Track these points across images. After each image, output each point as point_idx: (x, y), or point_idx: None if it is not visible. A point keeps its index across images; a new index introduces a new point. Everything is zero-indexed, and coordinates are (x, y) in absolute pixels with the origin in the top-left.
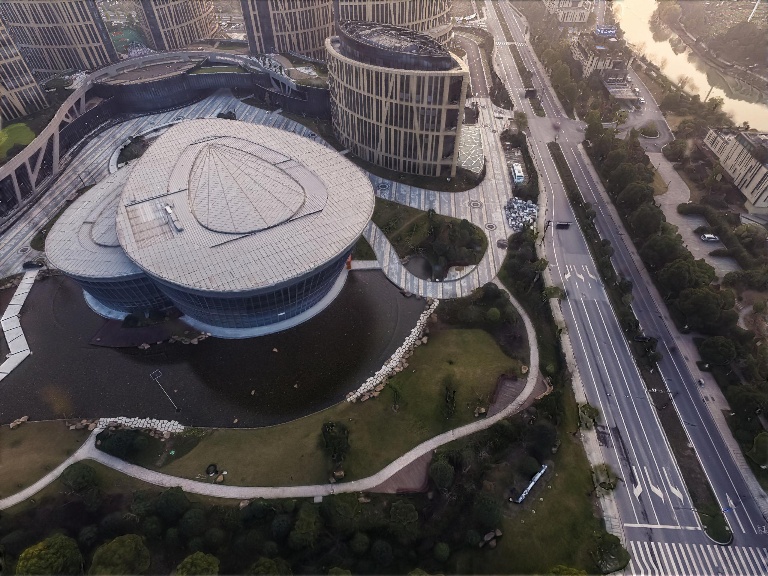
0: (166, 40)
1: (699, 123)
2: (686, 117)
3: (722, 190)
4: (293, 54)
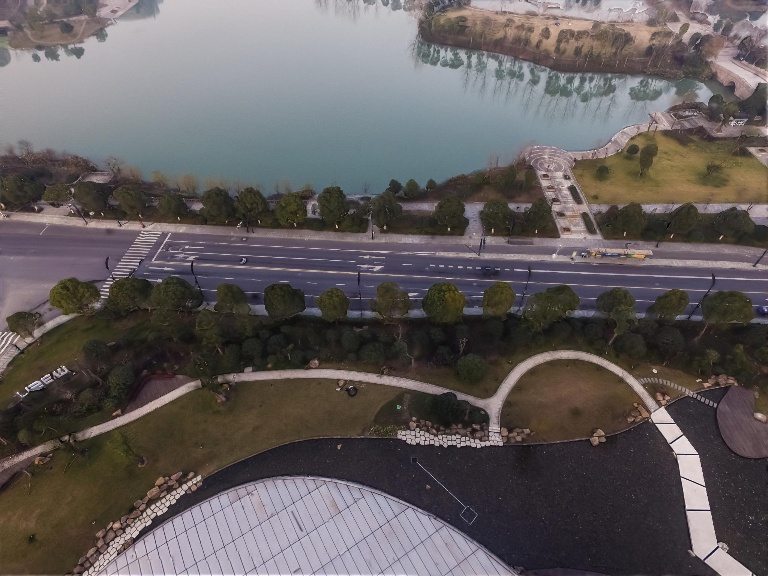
0: None
1: None
2: None
3: None
4: None
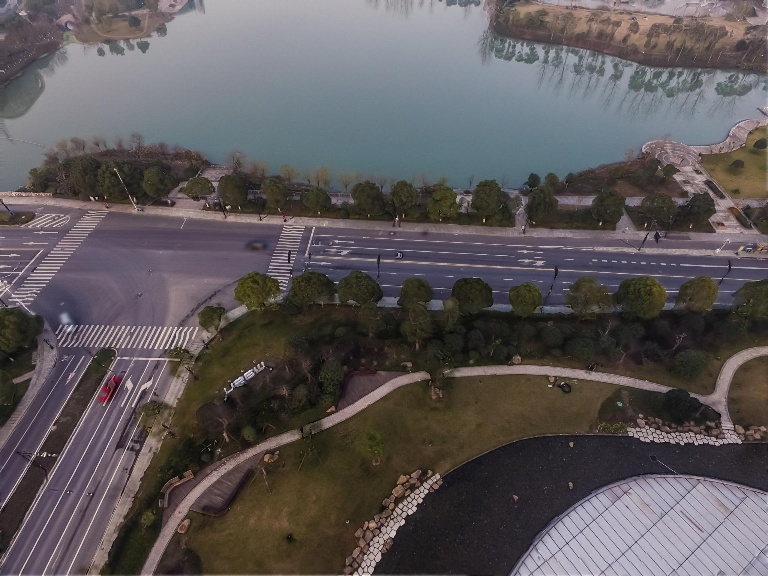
0: None
1: None
2: None
3: None
4: None
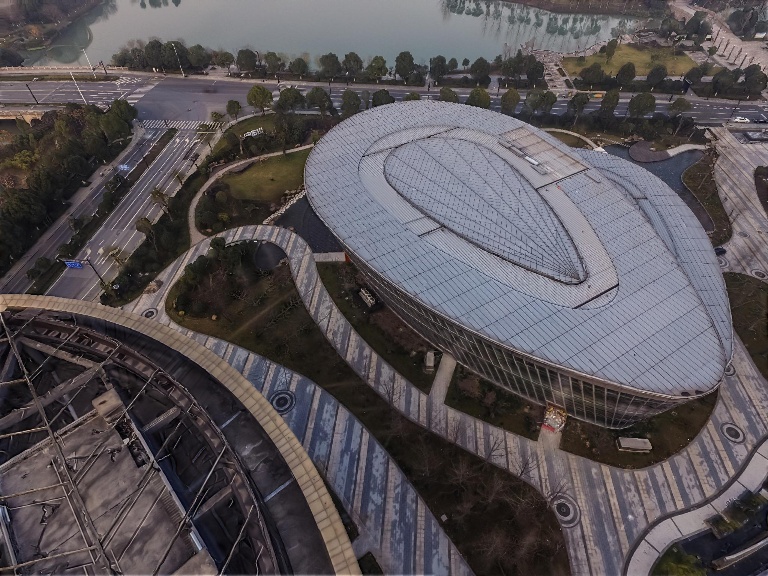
0: None
1: None
2: None
3: None
4: None
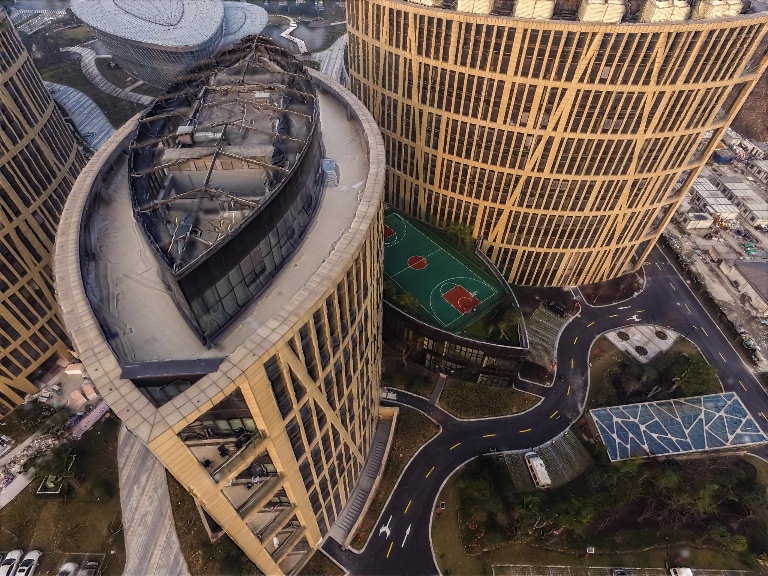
0: None
1: None
2: None
3: None
4: None
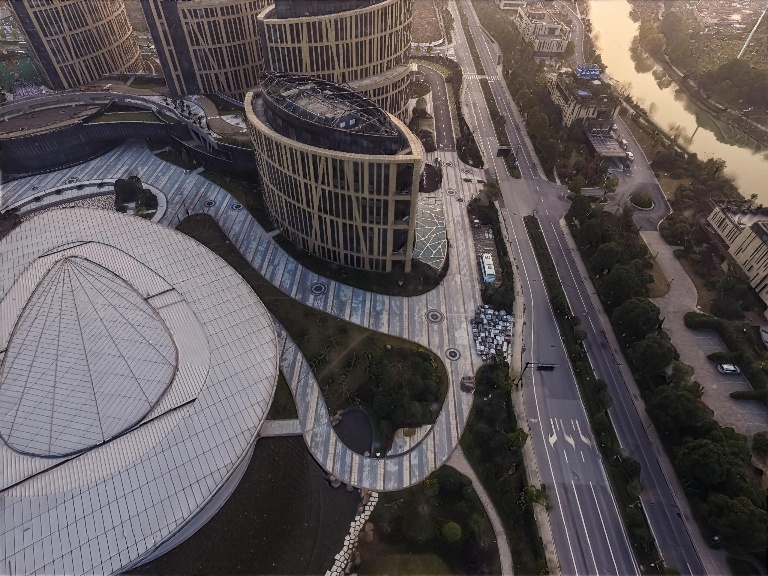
0: (64, 77)
1: (698, 190)
2: (682, 181)
3: (735, 291)
4: (221, 96)
